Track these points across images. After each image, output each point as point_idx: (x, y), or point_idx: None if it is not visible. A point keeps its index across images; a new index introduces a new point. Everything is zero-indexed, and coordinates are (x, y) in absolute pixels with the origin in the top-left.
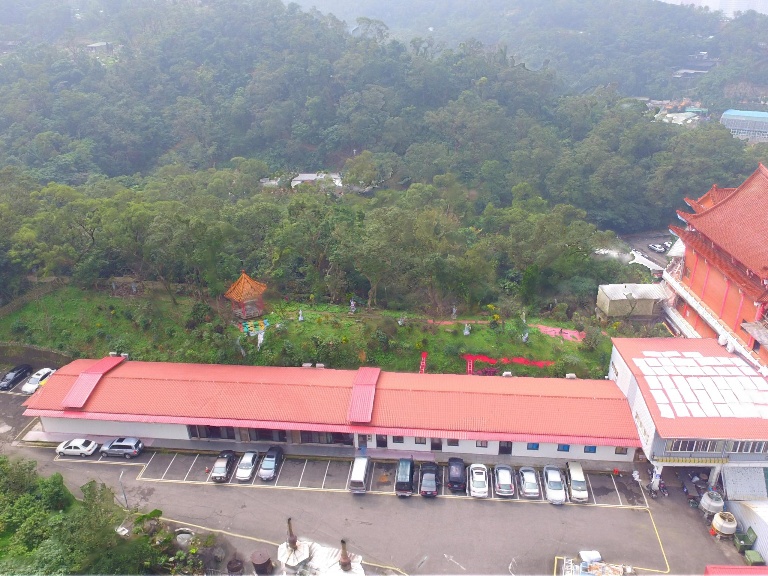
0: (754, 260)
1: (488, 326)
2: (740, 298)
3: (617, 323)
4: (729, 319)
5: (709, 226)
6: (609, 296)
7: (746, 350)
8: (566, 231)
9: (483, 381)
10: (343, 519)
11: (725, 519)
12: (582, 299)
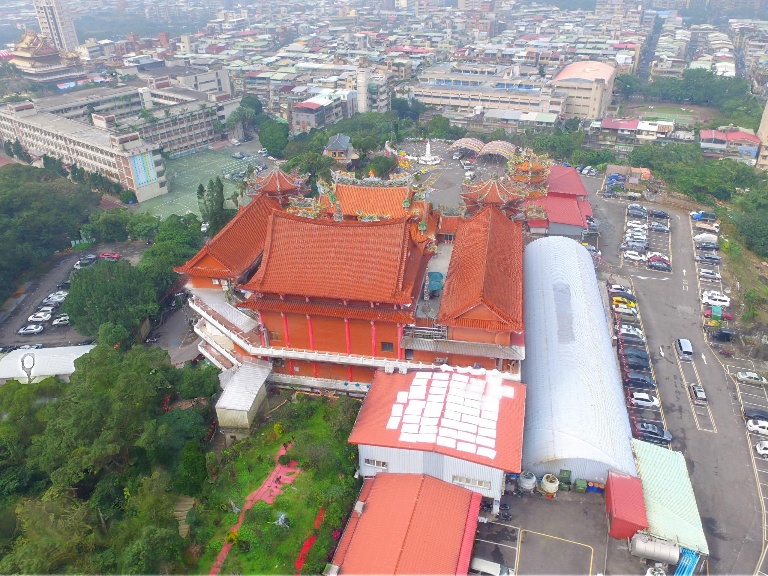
0: (374, 293)
1: (237, 555)
2: (370, 328)
3: (279, 426)
4: (363, 350)
5: (289, 285)
6: (242, 409)
7: (413, 363)
8: (112, 381)
9: None
10: None
11: (553, 481)
12: (202, 435)
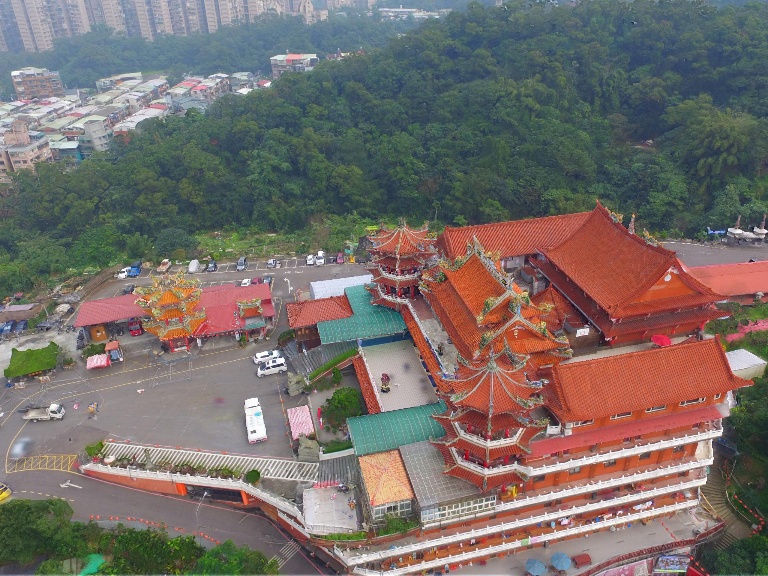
0: None
1: None
2: None
3: None
4: None
5: None
6: None
7: None
8: None
9: (767, 284)
10: (765, 257)
11: None
12: None
